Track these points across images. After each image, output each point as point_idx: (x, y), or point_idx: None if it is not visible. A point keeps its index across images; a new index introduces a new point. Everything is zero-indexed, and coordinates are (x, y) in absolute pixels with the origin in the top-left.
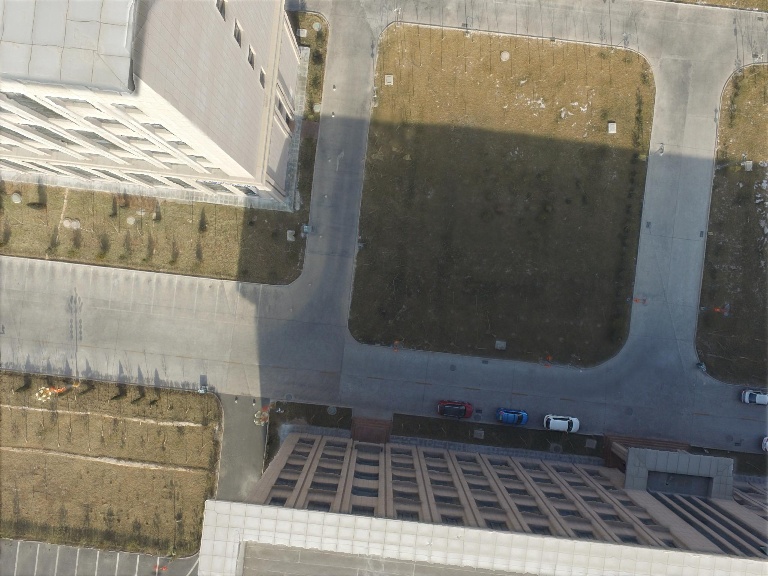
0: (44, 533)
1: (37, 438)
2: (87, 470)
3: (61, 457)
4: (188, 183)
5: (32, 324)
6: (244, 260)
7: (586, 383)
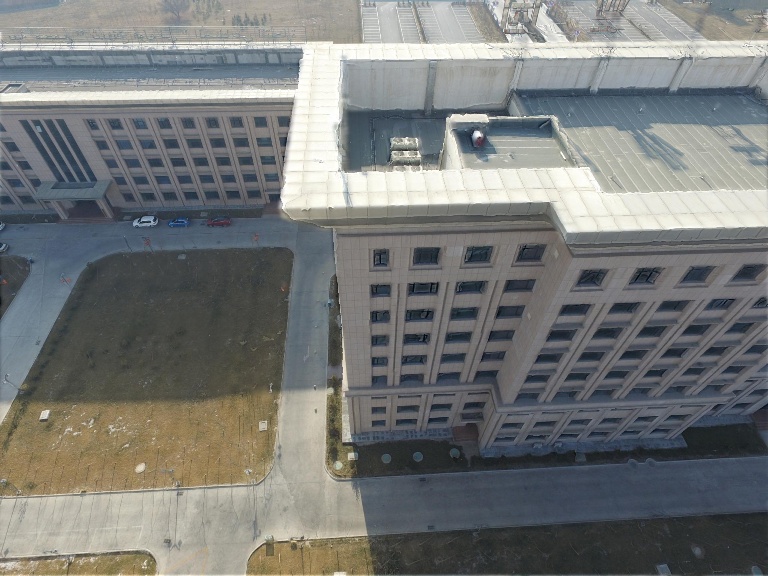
0: None
1: None
2: None
3: None
4: None
5: None
6: None
7: (122, 245)
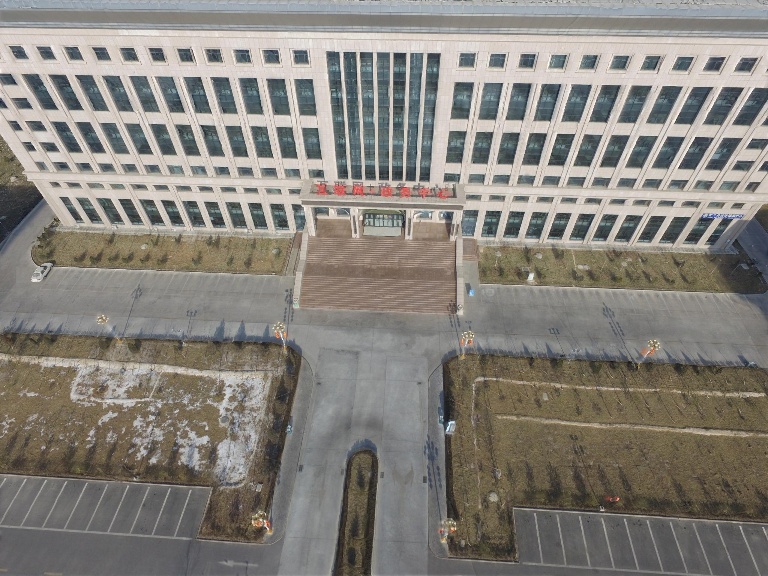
0: (670, 508)
1: (619, 414)
2: (680, 442)
3: (648, 431)
4: (689, 222)
5: (580, 327)
6: (720, 281)
7: None
